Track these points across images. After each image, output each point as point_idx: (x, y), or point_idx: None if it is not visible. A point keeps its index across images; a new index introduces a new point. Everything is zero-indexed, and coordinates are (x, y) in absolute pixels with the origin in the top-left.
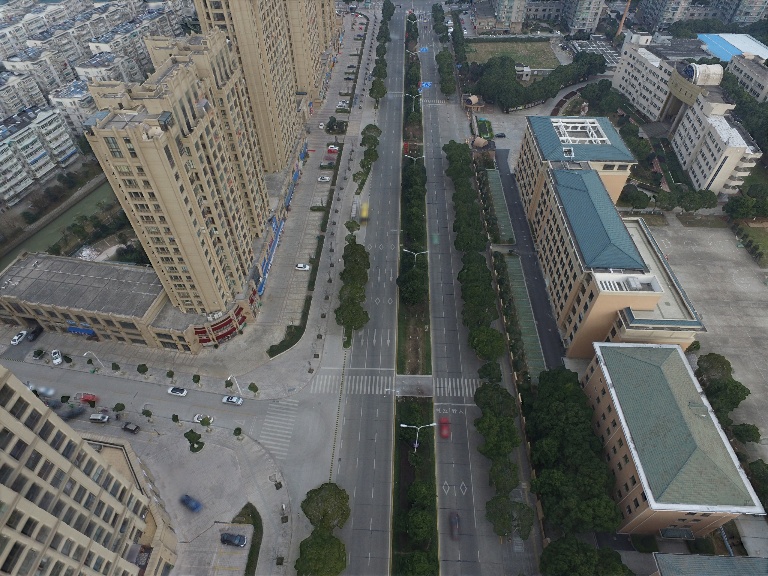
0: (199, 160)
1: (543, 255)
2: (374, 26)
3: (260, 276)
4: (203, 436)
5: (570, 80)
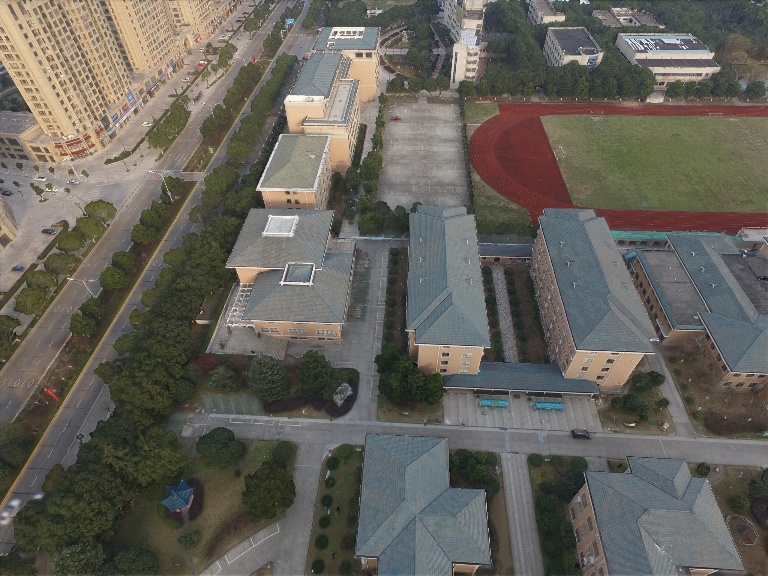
0: (38, 21)
1: None
2: None
3: (111, 123)
4: (49, 197)
5: None
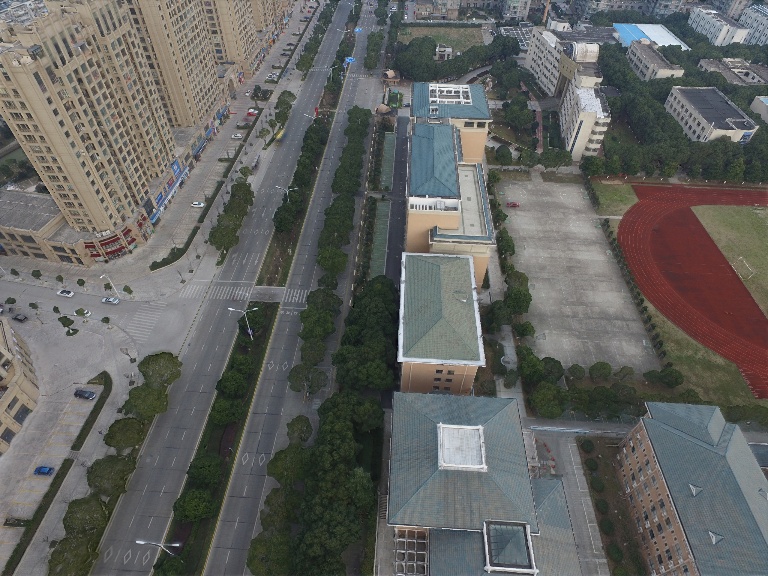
0: (73, 90)
1: None
2: (321, 9)
3: (154, 207)
4: (79, 325)
5: (487, 60)
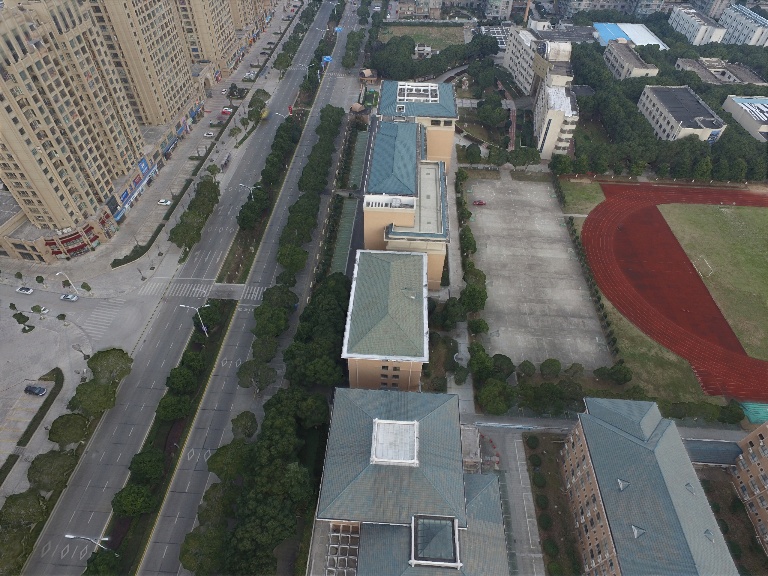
0: (27, 87)
1: None
2: (304, 8)
3: (119, 205)
4: (36, 322)
5: (465, 59)
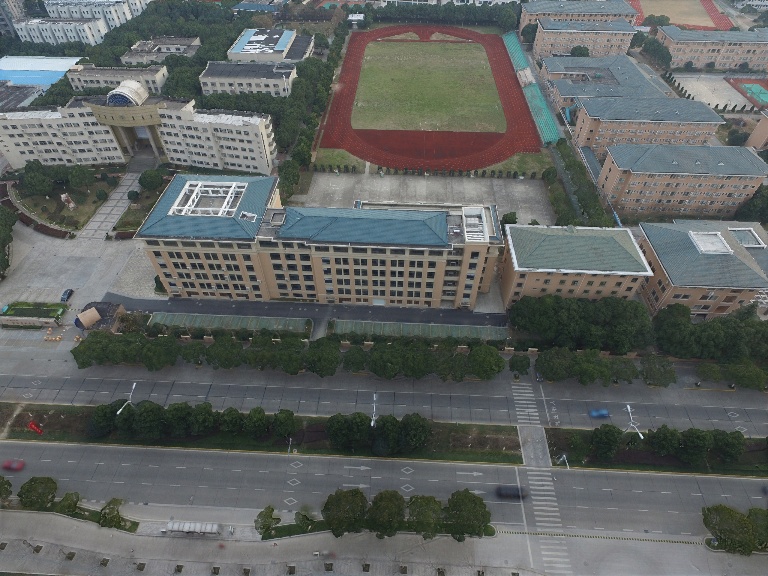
0: None
1: (348, 295)
2: None
3: None
4: None
5: None
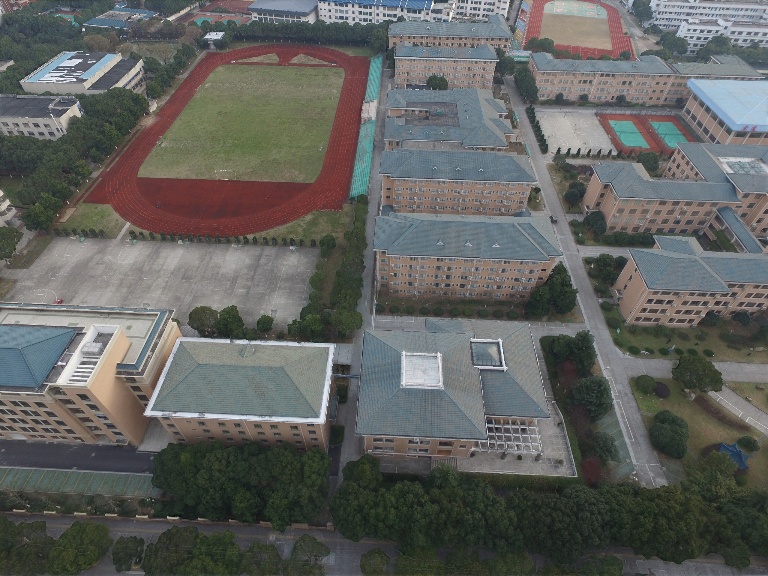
0: None
1: None
2: None
3: None
4: None
5: None
